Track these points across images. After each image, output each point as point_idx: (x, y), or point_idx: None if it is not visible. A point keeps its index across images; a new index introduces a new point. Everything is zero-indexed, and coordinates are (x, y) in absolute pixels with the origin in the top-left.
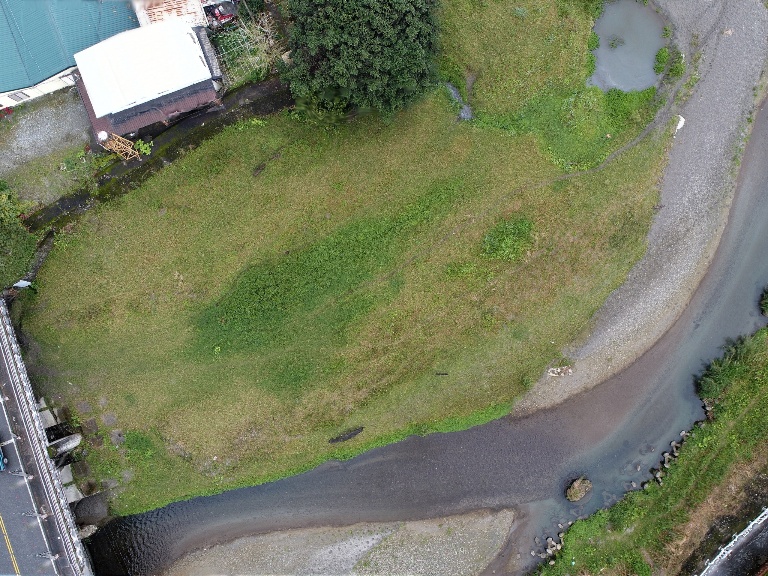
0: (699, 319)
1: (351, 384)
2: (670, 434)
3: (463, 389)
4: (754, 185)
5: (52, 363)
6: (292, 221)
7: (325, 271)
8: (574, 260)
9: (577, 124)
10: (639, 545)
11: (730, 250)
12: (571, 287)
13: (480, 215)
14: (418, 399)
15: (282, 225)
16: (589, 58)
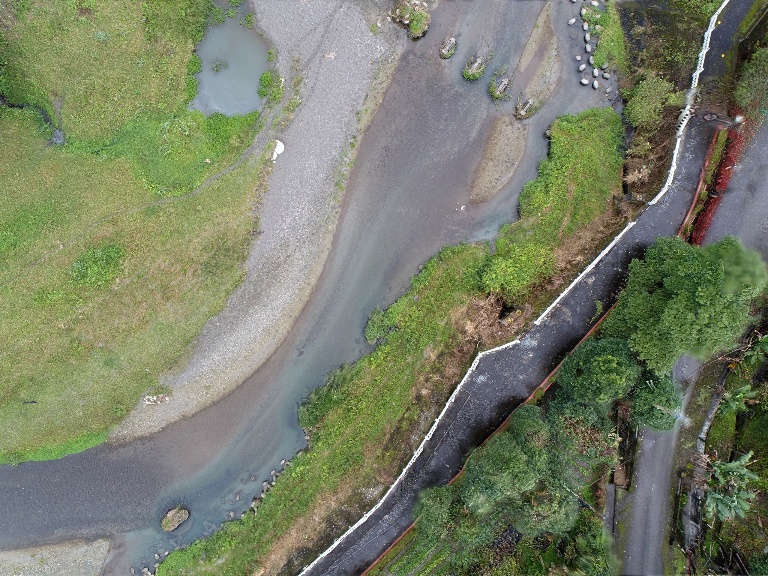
0: (303, 346)
1: None
2: (272, 463)
3: (55, 417)
4: (359, 210)
5: None
6: None
7: None
8: (164, 287)
9: (170, 149)
10: None
11: (335, 276)
12: (163, 314)
13: (70, 241)
14: (7, 427)
15: None
16: (189, 82)
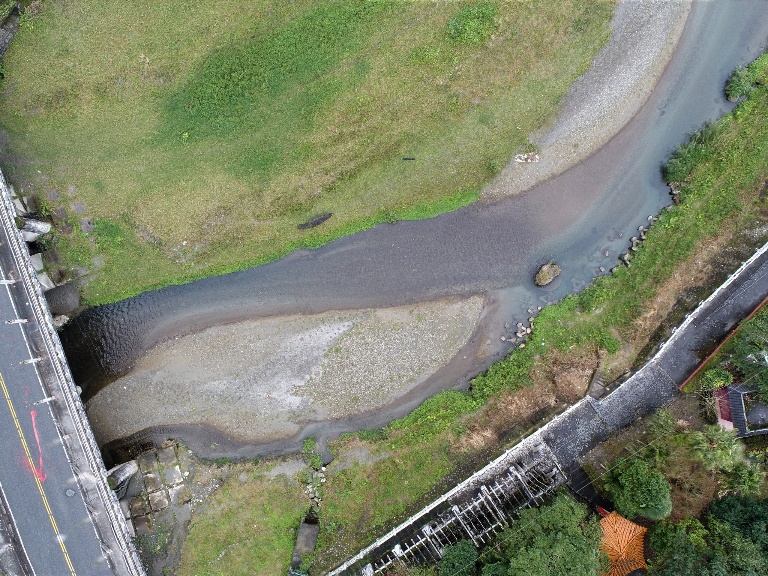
0: (664, 106)
1: (319, 168)
2: (638, 220)
3: (431, 175)
4: None
5: (21, 151)
6: (257, 4)
7: (291, 56)
8: (538, 43)
9: None
10: (608, 324)
11: (694, 37)
12: (536, 71)
13: (444, 1)
14: (386, 185)
15: (247, 8)
16: None
